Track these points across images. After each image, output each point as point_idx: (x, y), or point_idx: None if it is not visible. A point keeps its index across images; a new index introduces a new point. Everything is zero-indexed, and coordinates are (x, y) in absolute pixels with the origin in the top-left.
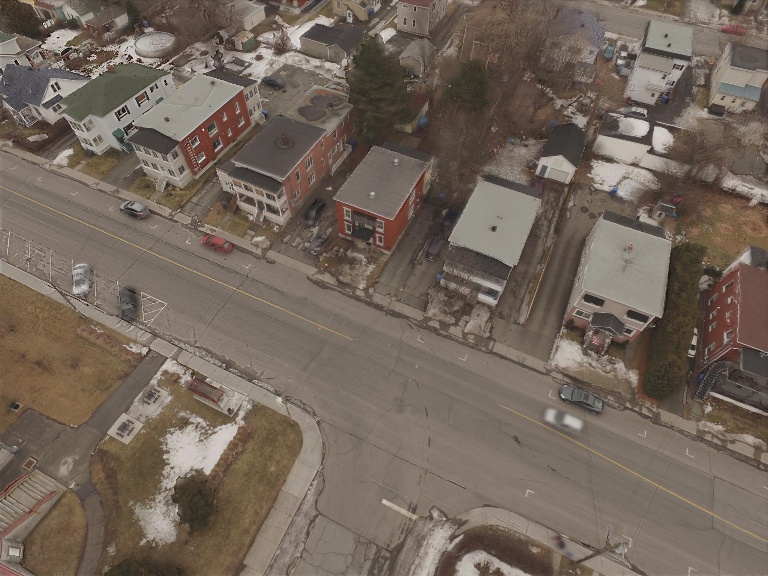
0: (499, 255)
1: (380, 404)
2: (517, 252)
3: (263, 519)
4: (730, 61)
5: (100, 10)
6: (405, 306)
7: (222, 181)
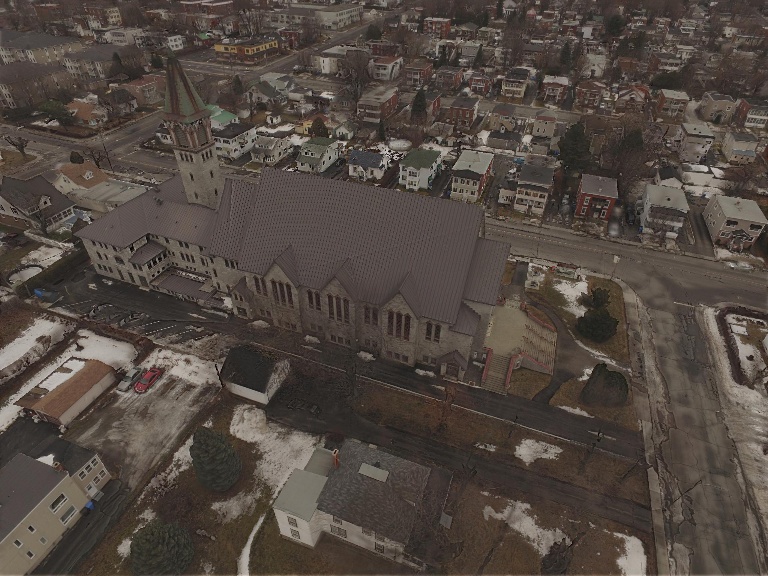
0: (679, 207)
1: (647, 273)
2: (687, 206)
3: (624, 310)
4: (734, 139)
5: (355, 130)
6: (630, 241)
7: (501, 196)
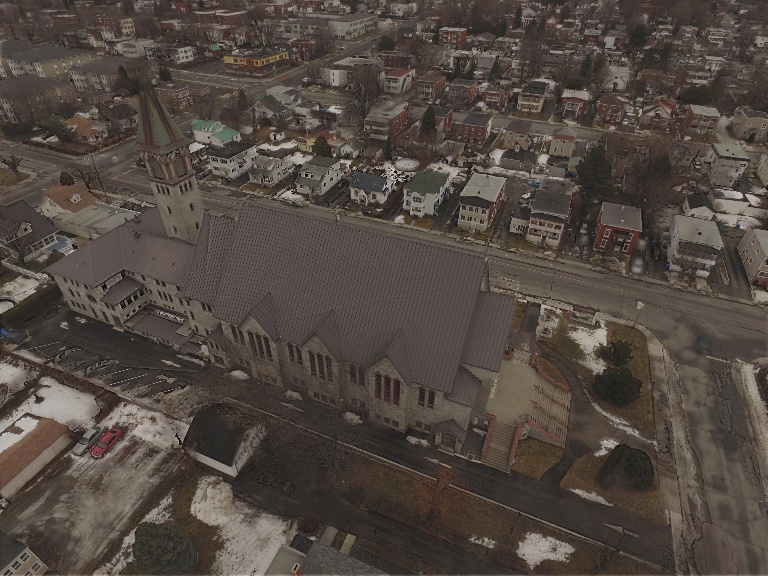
0: (712, 243)
1: (674, 319)
2: (720, 242)
3: (649, 365)
4: None
5: (360, 148)
6: (655, 280)
7: (512, 225)
